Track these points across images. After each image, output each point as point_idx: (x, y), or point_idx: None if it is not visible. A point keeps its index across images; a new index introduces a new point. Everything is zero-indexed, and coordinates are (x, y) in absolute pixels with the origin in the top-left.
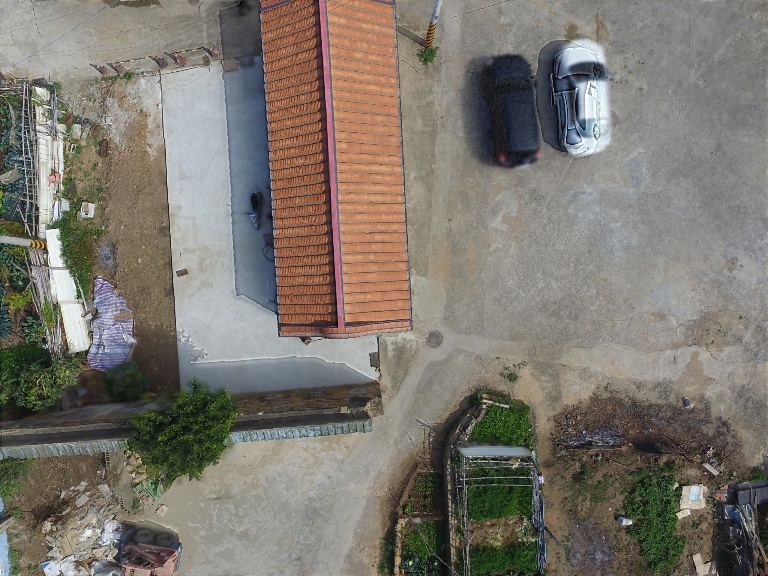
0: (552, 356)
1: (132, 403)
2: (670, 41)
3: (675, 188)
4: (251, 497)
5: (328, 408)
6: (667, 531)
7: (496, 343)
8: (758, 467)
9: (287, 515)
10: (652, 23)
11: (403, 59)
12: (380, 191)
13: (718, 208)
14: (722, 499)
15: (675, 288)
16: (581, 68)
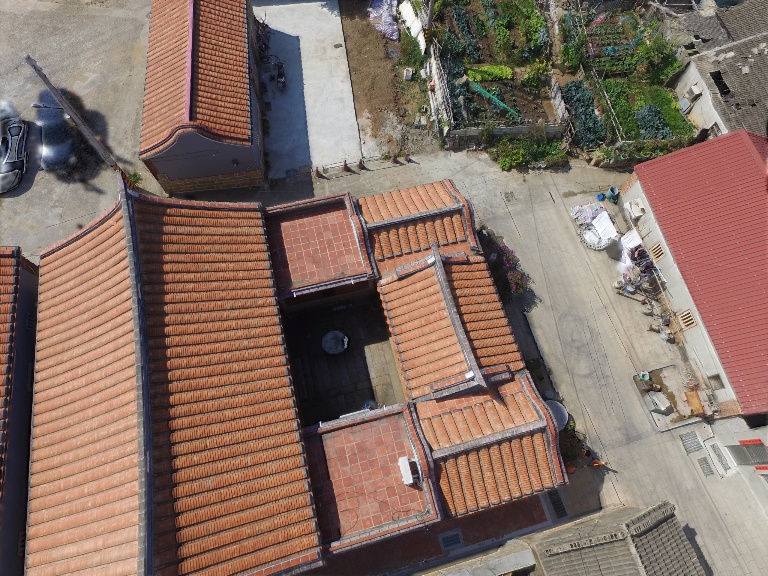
0: (65, 7)
1: None
2: None
3: None
4: None
5: None
6: None
7: (107, 14)
8: None
9: None
10: None
11: None
12: None
13: None
14: None
15: None
16: None
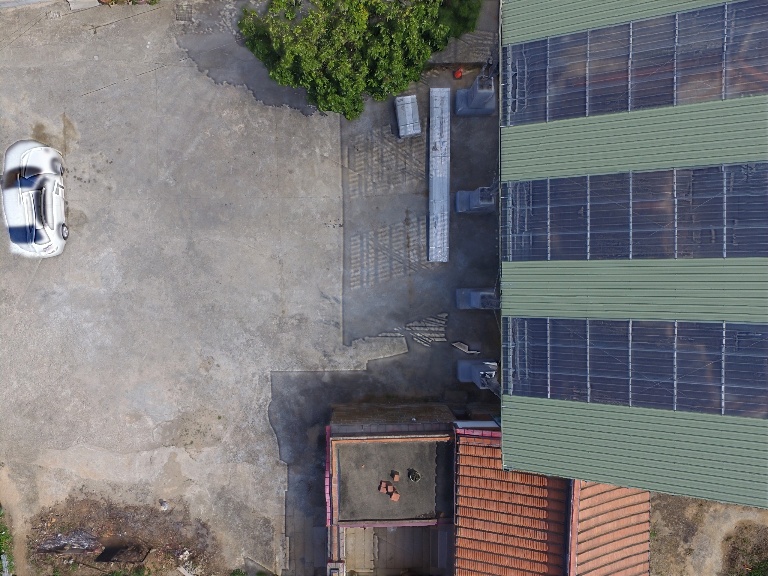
0: (28, 457)
1: None
2: (138, 140)
3: (147, 288)
4: None
5: None
6: None
7: None
8: (238, 570)
9: None
10: (119, 122)
11: None
12: None
13: (192, 307)
14: None
15: (151, 388)
16: (48, 168)
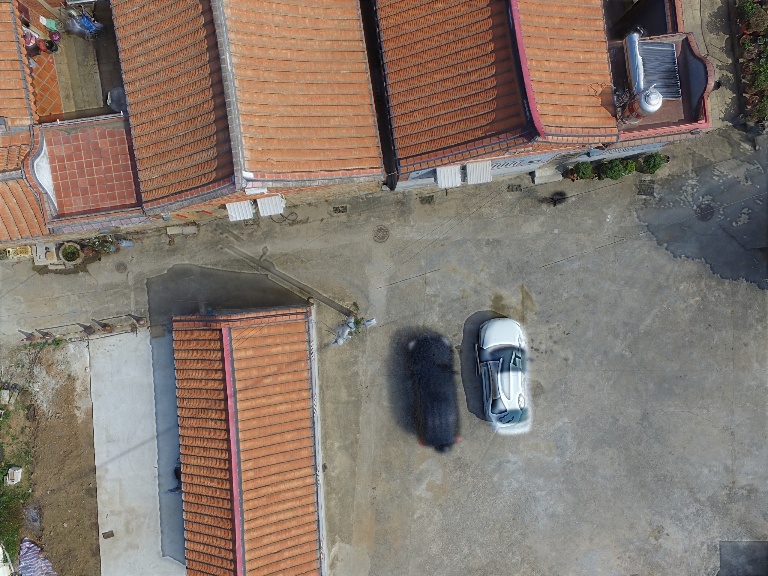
0: None
1: None
2: (595, 312)
3: (600, 457)
4: None
5: None
6: None
7: None
8: None
9: None
10: (577, 294)
11: (328, 329)
12: (290, 507)
13: (644, 477)
14: None
15: (600, 556)
16: (506, 338)
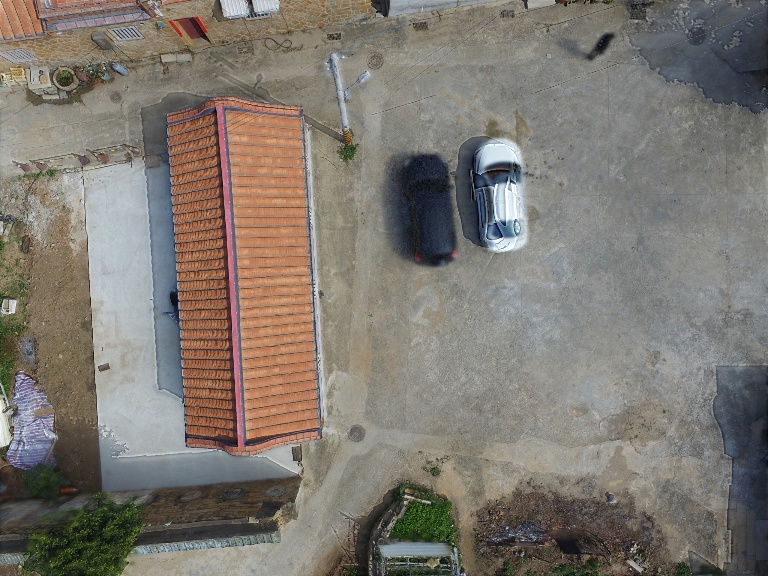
0: (475, 451)
1: (51, 500)
2: (589, 137)
3: (596, 283)
4: None
5: (236, 518)
6: None
7: (419, 437)
8: (684, 563)
9: None
10: (571, 119)
11: (323, 156)
12: (286, 303)
13: (640, 302)
14: None
15: (598, 382)
16: (501, 164)
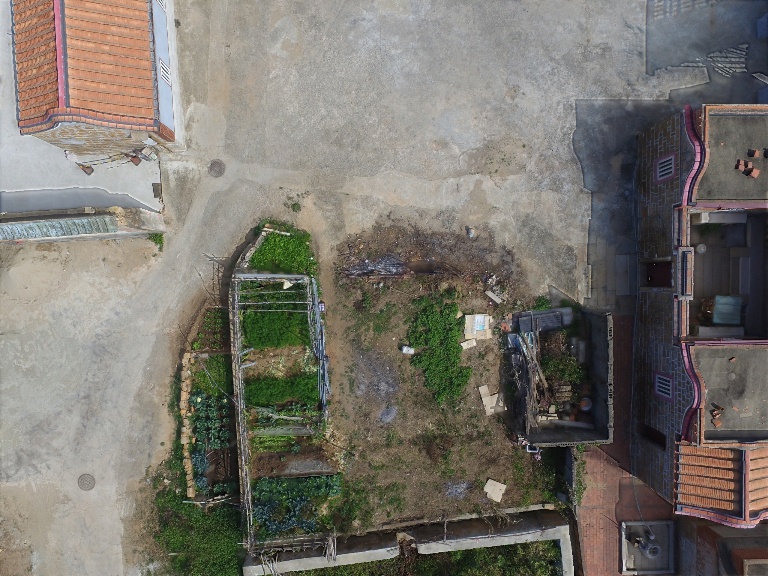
0: (335, 185)
1: None
2: None
3: (455, 15)
4: (37, 333)
5: None
6: (450, 360)
7: (279, 172)
8: (543, 296)
9: (74, 352)
10: None
11: None
12: None
13: (499, 35)
14: (507, 329)
15: (457, 116)
16: None
